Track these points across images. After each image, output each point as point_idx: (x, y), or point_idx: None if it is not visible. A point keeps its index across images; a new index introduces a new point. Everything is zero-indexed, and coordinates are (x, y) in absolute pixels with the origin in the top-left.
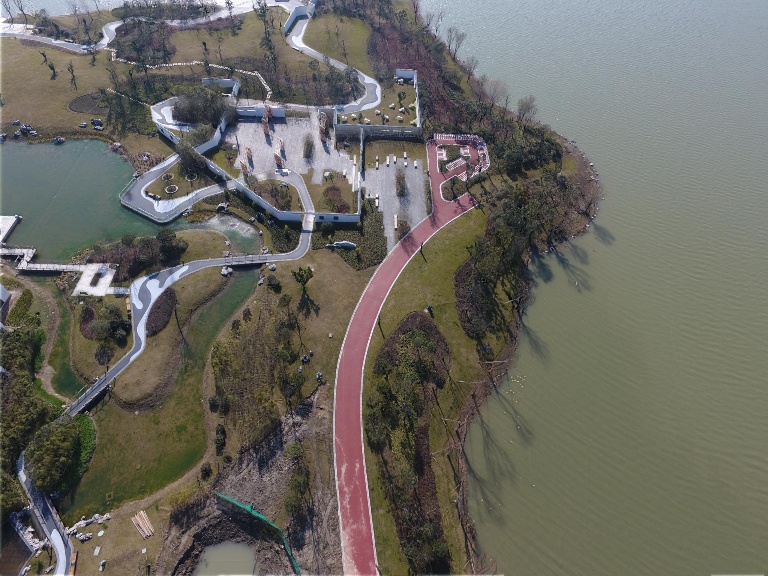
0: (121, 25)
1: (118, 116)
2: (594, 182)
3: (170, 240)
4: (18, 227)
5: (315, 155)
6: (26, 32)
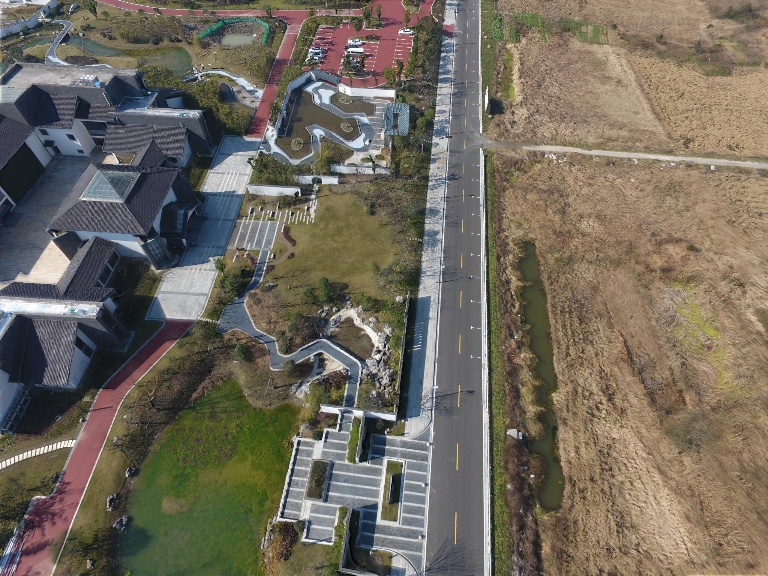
0: None
1: None
2: None
3: None
4: None
5: None
6: None
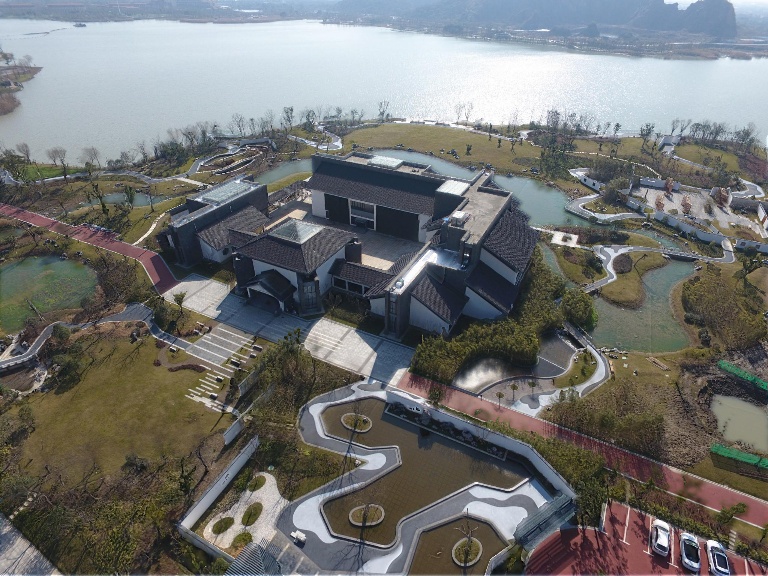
0: (530, 132)
1: (548, 170)
2: None
3: (622, 228)
4: None
5: (716, 213)
6: (469, 128)
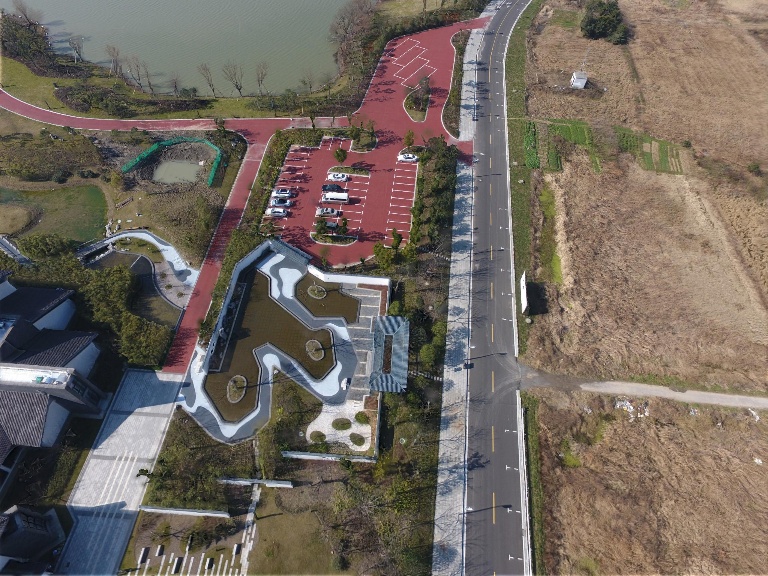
0: None
1: None
2: (7, 16)
3: None
4: None
5: None
6: None
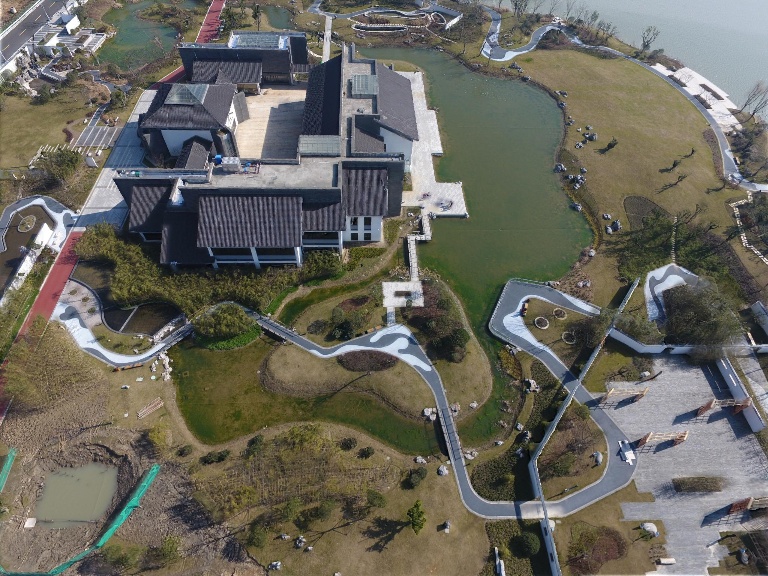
0: None
1: None
2: None
3: (454, 343)
4: (457, 219)
5: (688, 499)
6: (726, 128)
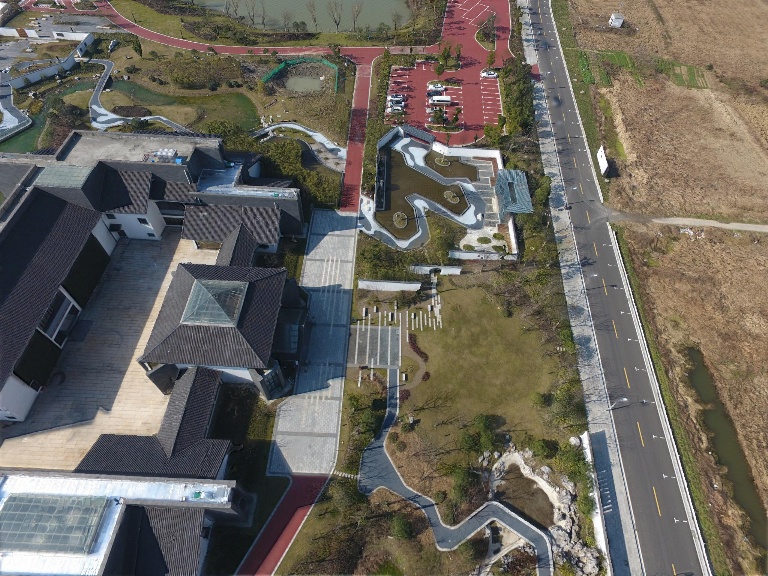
0: None
1: None
2: None
3: (64, 102)
4: None
5: None
6: None
